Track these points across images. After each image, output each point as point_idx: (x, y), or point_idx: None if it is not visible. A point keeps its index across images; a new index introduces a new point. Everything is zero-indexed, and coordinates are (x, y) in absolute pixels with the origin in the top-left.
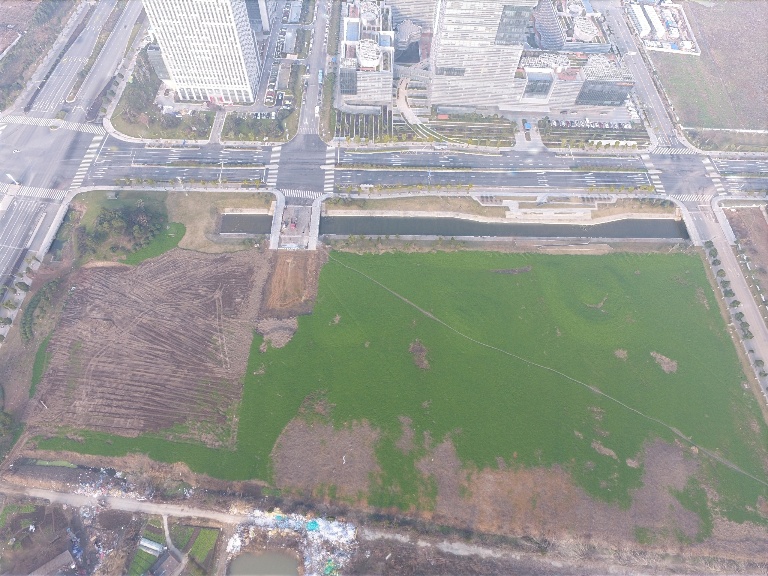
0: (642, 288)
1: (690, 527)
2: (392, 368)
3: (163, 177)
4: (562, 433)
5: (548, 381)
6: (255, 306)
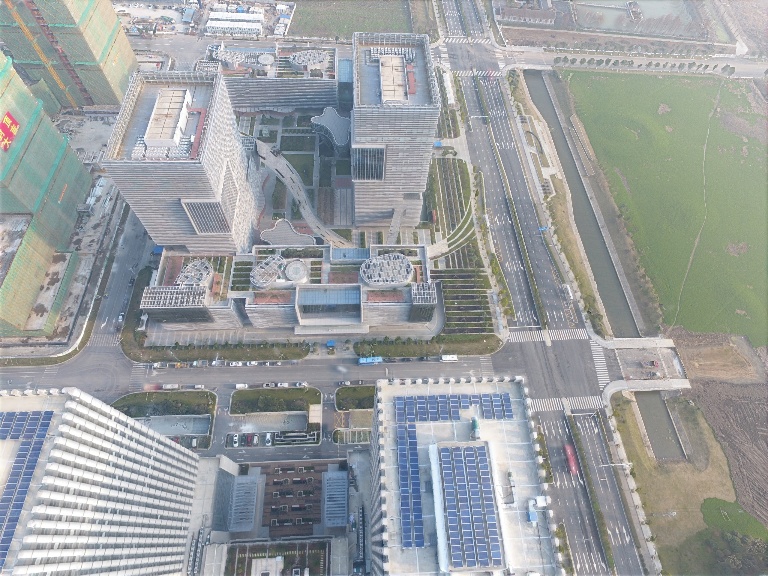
0: (606, 106)
1: (767, 123)
2: (760, 268)
3: (635, 566)
4: (747, 170)
5: (714, 171)
6: (765, 390)
